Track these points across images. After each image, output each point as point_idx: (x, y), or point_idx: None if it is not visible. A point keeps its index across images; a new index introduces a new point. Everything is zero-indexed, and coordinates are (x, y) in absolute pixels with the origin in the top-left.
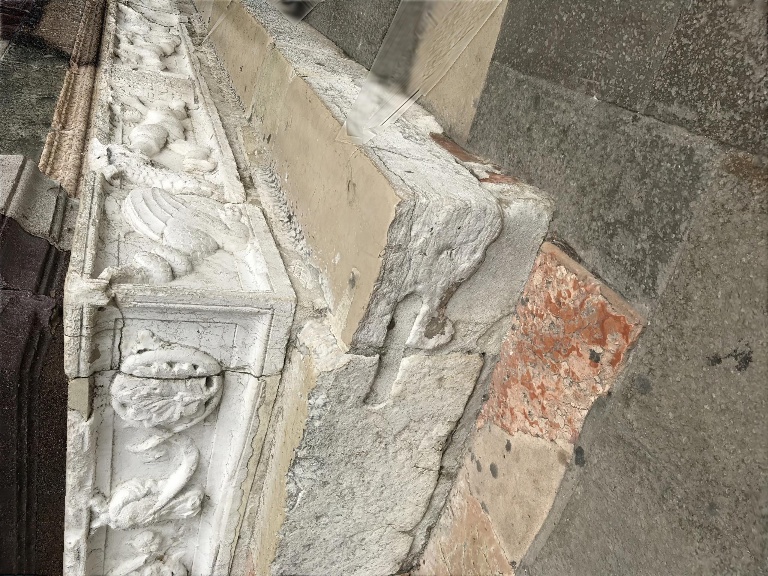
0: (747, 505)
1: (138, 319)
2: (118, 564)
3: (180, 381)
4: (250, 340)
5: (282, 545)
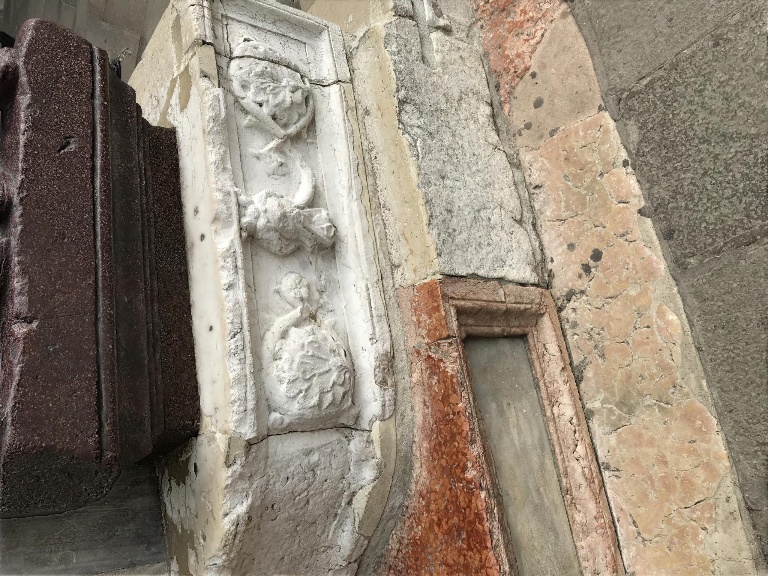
0: None
1: (236, 21)
2: (273, 319)
3: (282, 66)
4: (319, 58)
5: (428, 201)
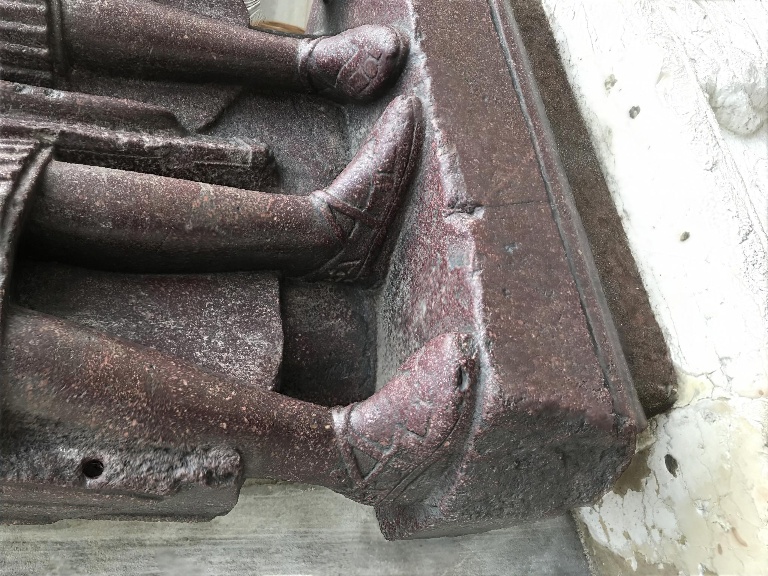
0: None
1: None
2: (767, 223)
3: None
4: None
5: None
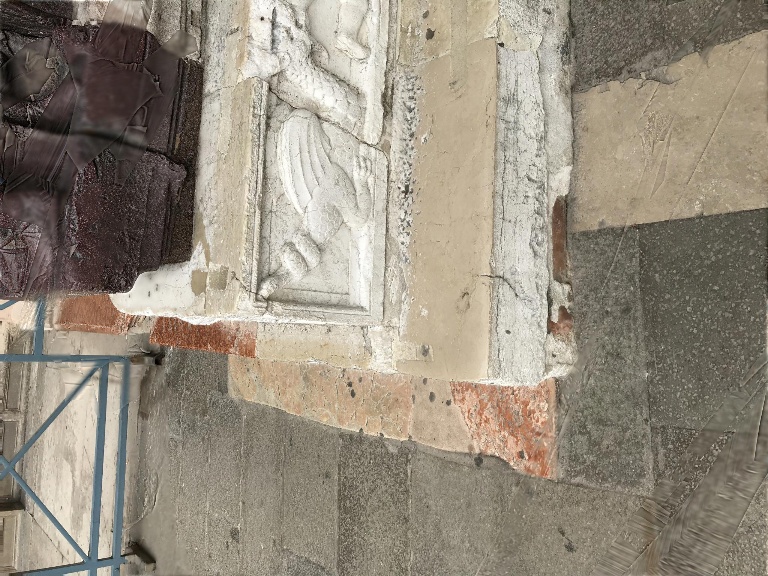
0: (523, 572)
1: None
2: None
3: None
4: None
5: None
